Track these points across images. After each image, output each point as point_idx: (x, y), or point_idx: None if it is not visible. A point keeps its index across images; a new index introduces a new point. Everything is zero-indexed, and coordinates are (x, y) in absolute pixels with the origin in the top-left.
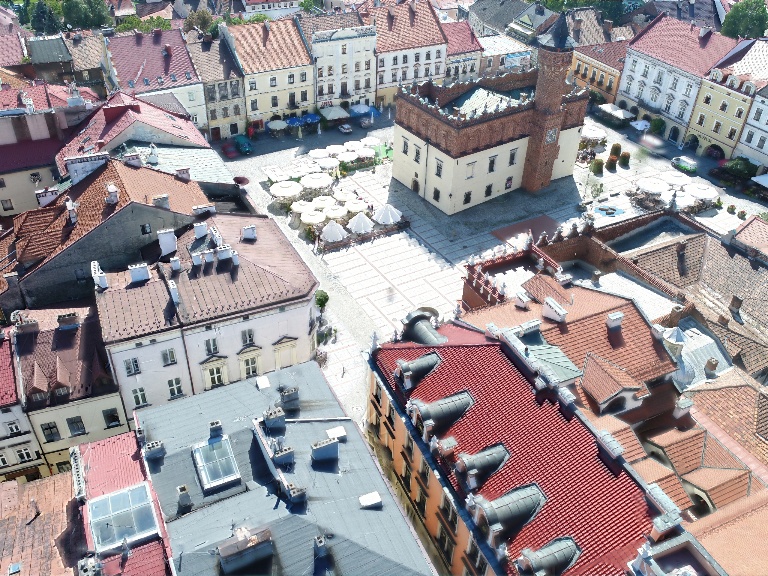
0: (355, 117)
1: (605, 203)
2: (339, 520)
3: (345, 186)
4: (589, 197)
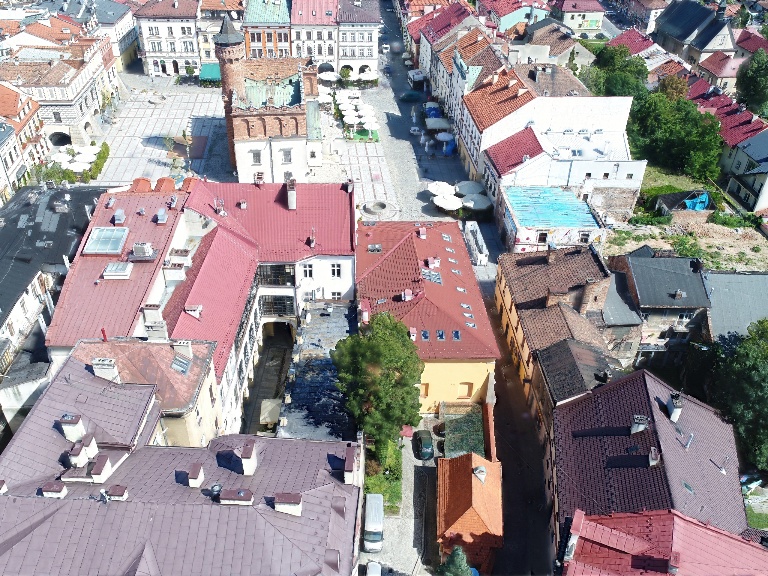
0: (447, 143)
1: None
2: (45, 6)
3: (322, 115)
4: None
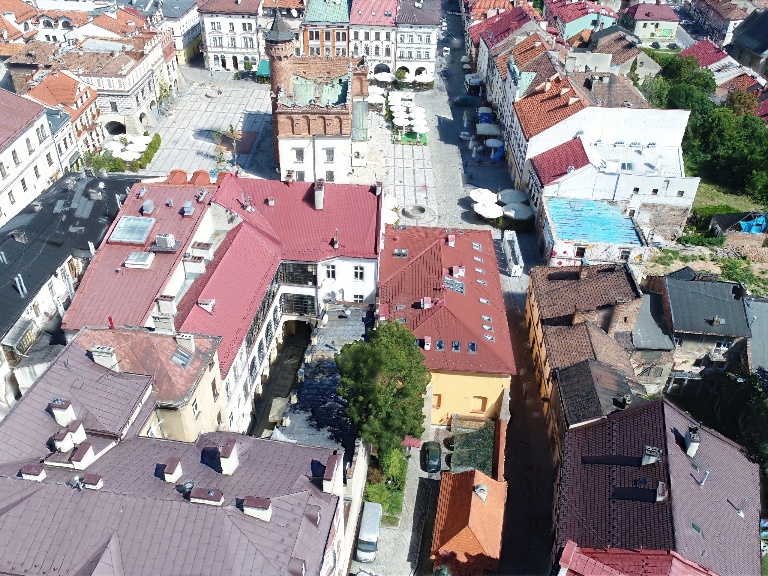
0: (496, 150)
1: None
2: None
3: (373, 116)
4: (246, 176)
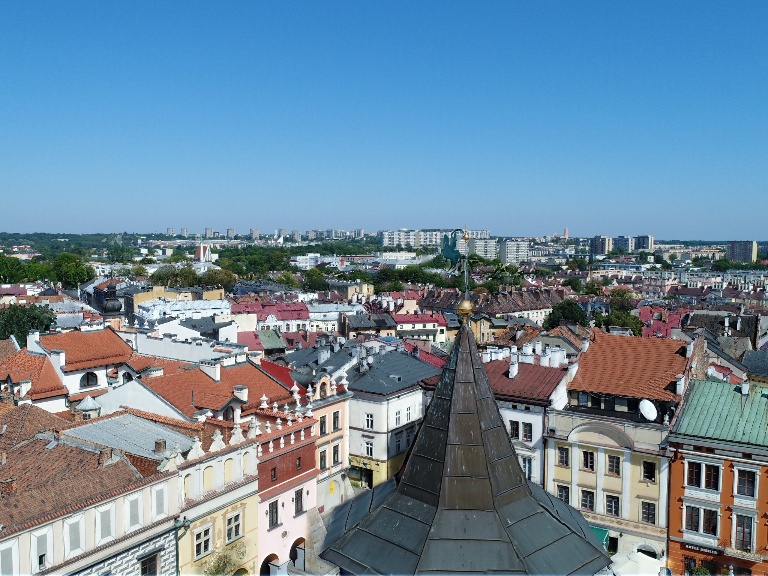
0: None
1: None
2: None
3: None
4: None
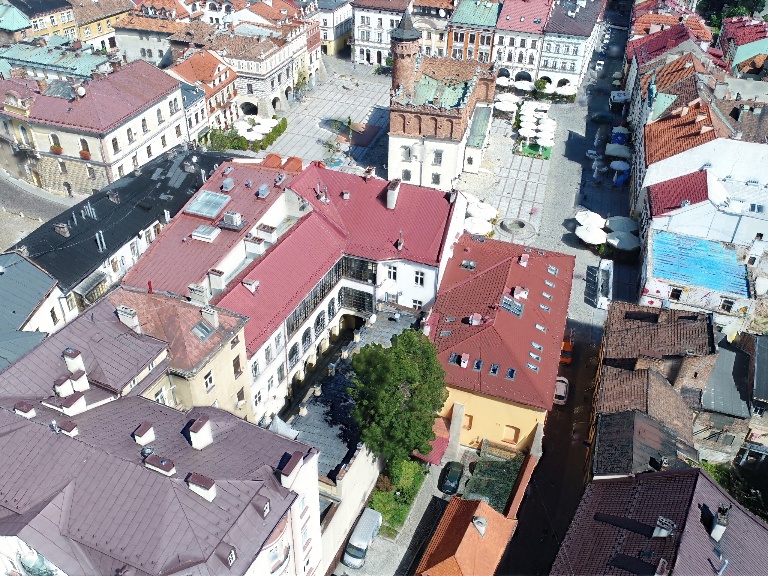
0: (622, 173)
1: (341, 167)
2: None
3: (501, 123)
4: (356, 169)
